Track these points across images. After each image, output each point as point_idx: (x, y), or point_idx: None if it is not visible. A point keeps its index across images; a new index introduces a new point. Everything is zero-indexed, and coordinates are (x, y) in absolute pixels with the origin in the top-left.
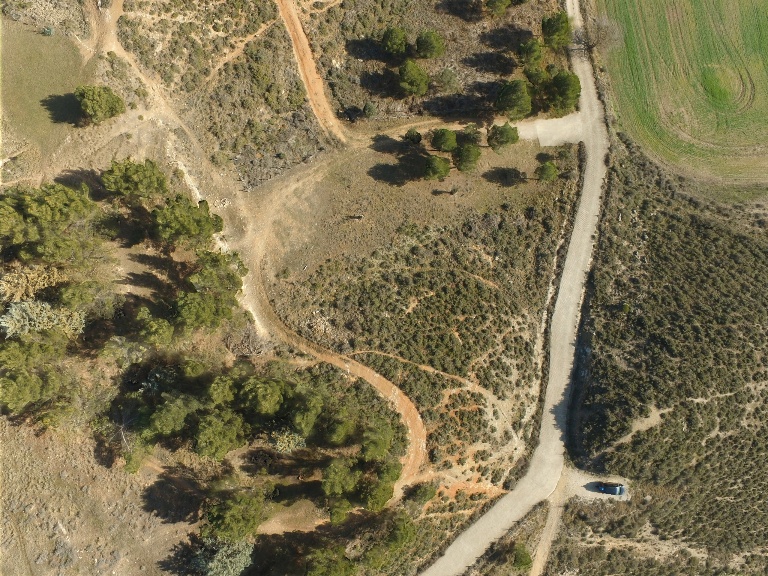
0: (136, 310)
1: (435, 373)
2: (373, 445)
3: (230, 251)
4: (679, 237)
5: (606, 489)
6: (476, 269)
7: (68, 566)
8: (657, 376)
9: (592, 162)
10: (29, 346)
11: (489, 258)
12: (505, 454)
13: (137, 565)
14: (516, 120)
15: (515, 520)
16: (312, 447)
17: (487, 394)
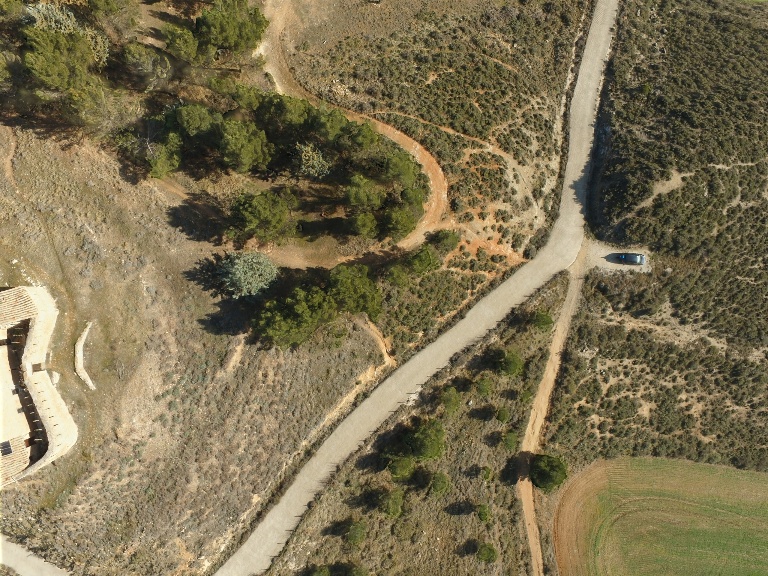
0: None
1: (455, 135)
2: (397, 158)
3: None
4: (698, 31)
5: (627, 257)
6: (495, 52)
7: (96, 261)
8: (678, 144)
9: None
10: (56, 38)
11: (508, 45)
12: (525, 220)
13: (163, 274)
14: None
15: (535, 287)
16: (334, 185)
17: (507, 158)
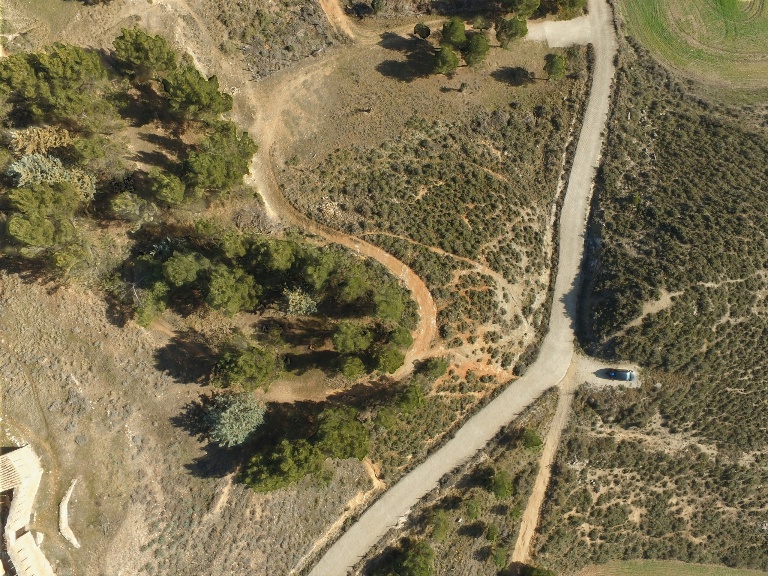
0: (146, 186)
1: (445, 255)
2: (385, 303)
3: (239, 138)
4: (688, 135)
5: (616, 374)
6: (485, 162)
7: (81, 415)
8: (667, 261)
9: (601, 63)
10: (41, 193)
11: (498, 153)
12: (515, 338)
13: (149, 421)
14: (525, 15)
15: (525, 405)
16: (323, 317)
17: (497, 277)
